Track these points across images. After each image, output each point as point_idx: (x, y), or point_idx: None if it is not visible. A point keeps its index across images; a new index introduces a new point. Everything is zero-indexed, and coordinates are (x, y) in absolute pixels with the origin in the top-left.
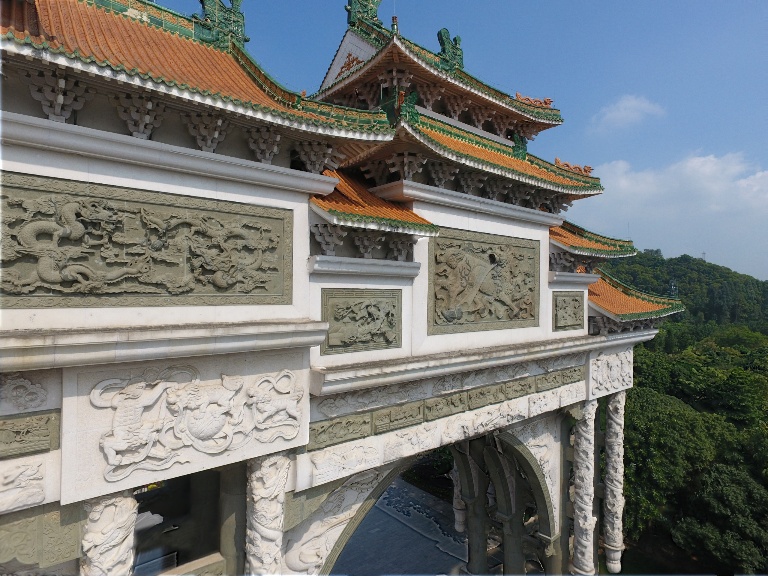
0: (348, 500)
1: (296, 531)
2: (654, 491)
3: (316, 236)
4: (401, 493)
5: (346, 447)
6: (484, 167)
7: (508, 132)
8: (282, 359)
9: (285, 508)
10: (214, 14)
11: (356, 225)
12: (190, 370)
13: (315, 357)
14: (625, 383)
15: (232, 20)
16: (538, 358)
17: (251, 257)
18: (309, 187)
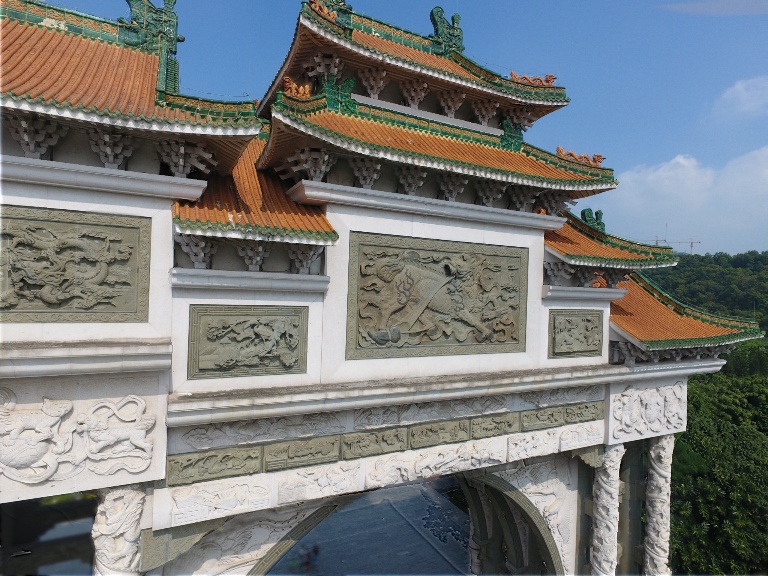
0: (257, 538)
1: (183, 568)
2: (732, 562)
3: (182, 246)
4: (443, 515)
5: (223, 484)
6: (416, 161)
7: (500, 119)
8: (129, 383)
9: (143, 546)
10: (142, 16)
11: (210, 234)
12: (3, 392)
13: (180, 381)
14: (671, 426)
15: (163, 20)
16: (513, 392)
17: (94, 270)
18: (167, 192)
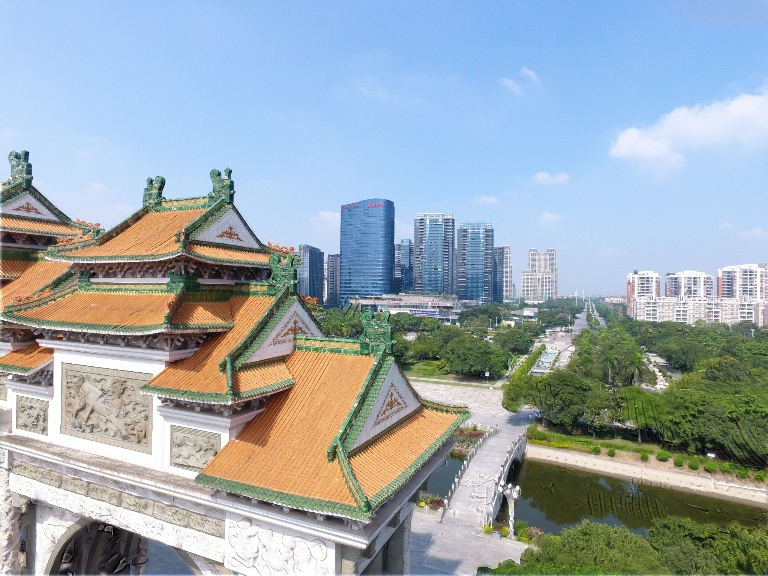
0: None
1: (45, 515)
2: None
3: None
4: None
5: (25, 479)
6: (56, 328)
7: None
8: (0, 425)
9: None
10: None
11: None
12: None
13: (14, 428)
14: None
15: None
16: (124, 482)
17: None
18: None
